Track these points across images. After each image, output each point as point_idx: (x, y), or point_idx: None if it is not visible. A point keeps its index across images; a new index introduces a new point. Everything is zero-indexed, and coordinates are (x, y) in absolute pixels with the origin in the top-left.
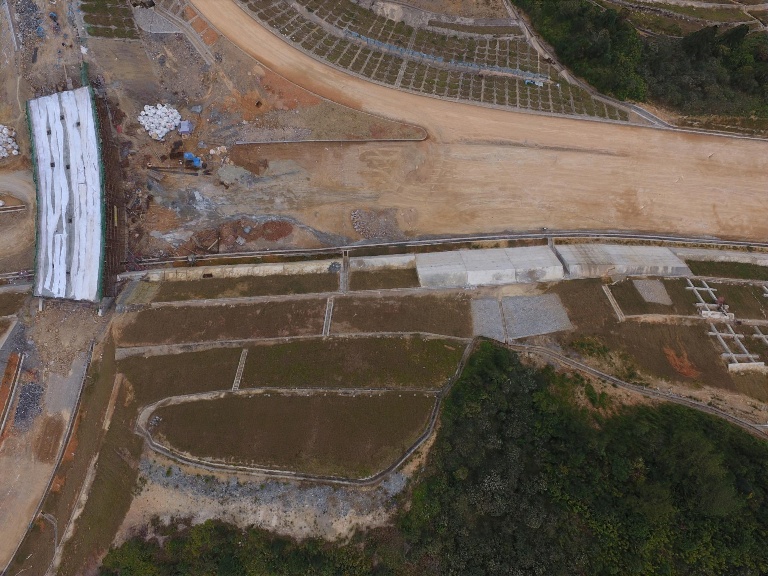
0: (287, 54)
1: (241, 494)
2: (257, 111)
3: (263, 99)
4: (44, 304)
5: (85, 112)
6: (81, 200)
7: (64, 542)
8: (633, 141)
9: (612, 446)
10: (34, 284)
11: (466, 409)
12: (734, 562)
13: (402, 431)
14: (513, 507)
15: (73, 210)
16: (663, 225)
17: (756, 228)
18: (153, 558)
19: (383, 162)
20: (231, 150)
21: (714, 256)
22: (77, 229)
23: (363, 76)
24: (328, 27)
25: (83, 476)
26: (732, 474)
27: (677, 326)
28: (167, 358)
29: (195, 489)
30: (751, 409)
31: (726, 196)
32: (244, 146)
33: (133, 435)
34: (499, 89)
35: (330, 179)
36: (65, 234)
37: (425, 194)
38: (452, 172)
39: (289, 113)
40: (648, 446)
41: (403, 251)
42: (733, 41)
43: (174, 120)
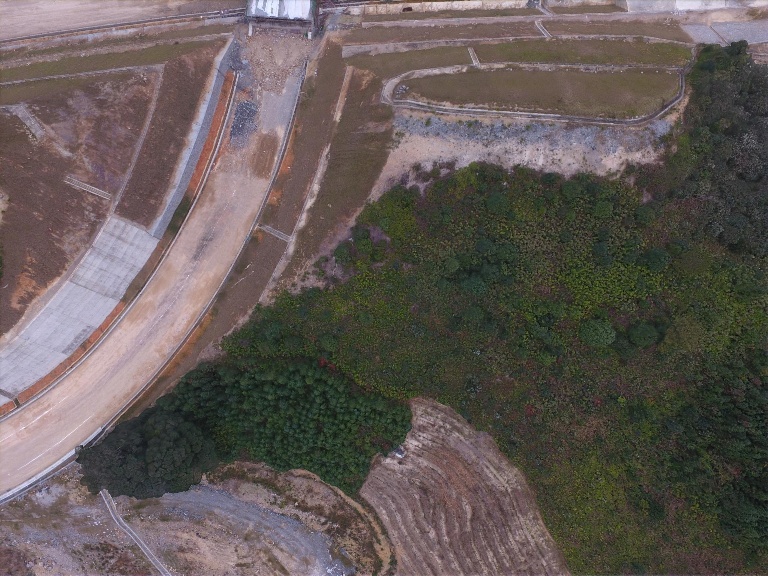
0: None
1: (506, 135)
2: None
3: None
4: (254, 29)
5: None
6: None
7: (297, 231)
8: None
9: None
10: (247, 5)
11: (718, 74)
12: None
13: (657, 90)
14: None
15: None
16: None
17: None
18: (416, 203)
19: None
20: None
21: None
22: None
23: None
24: None
25: (314, 168)
26: None
27: None
28: (394, 54)
29: (458, 134)
30: None
31: None
32: None
33: (379, 105)
34: None
35: None
36: None
37: None
38: None
39: None
40: None
41: None
42: None
43: None
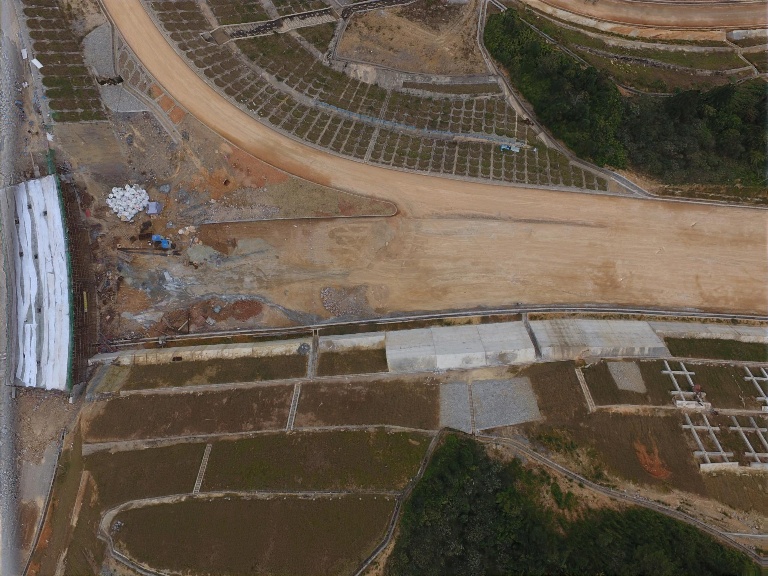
0: (254, 130)
1: None
2: (225, 189)
3: (231, 177)
4: (17, 391)
5: (52, 201)
6: (49, 290)
7: None
8: (611, 211)
9: (574, 556)
10: (6, 373)
11: (425, 517)
12: None
13: (359, 541)
14: None
15: (42, 300)
16: (643, 298)
17: (741, 299)
18: None
19: (353, 238)
20: (200, 230)
21: (695, 333)
22: (46, 319)
23: (332, 151)
24: (298, 96)
25: (53, 570)
26: None
27: (650, 418)
28: (132, 454)
29: None
30: (721, 516)
31: (710, 266)
32: (212, 226)
33: (96, 539)
34: (473, 158)
35: (299, 257)
36: (35, 324)
37: (396, 270)
38: (423, 247)
39: (257, 191)
40: (610, 560)
41: (374, 329)
42: (720, 101)
43: (142, 201)
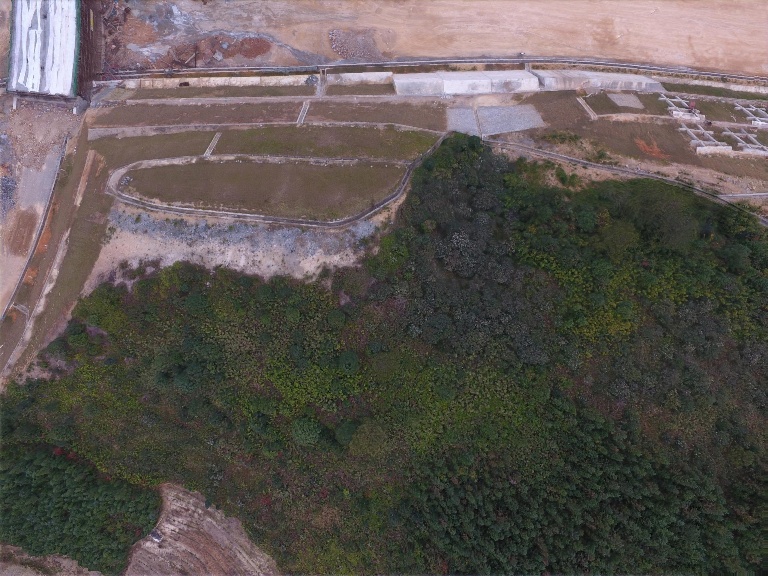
0: None
1: (209, 235)
2: None
3: None
4: (18, 102)
5: None
6: None
7: (35, 316)
8: None
9: None
10: (8, 79)
11: (436, 172)
12: (694, 293)
13: (372, 188)
14: (481, 265)
15: (48, 6)
16: (639, 55)
17: (730, 61)
18: (121, 301)
19: None
20: None
21: (688, 80)
22: (52, 24)
23: None
24: None
25: (54, 252)
26: (695, 219)
27: (648, 124)
28: (140, 138)
29: (164, 232)
30: (717, 181)
31: (701, 28)
32: None
33: (103, 196)
34: None
35: None
36: (40, 29)
37: (403, 16)
38: None
39: None
40: (614, 202)
41: (381, 71)
42: None
43: None
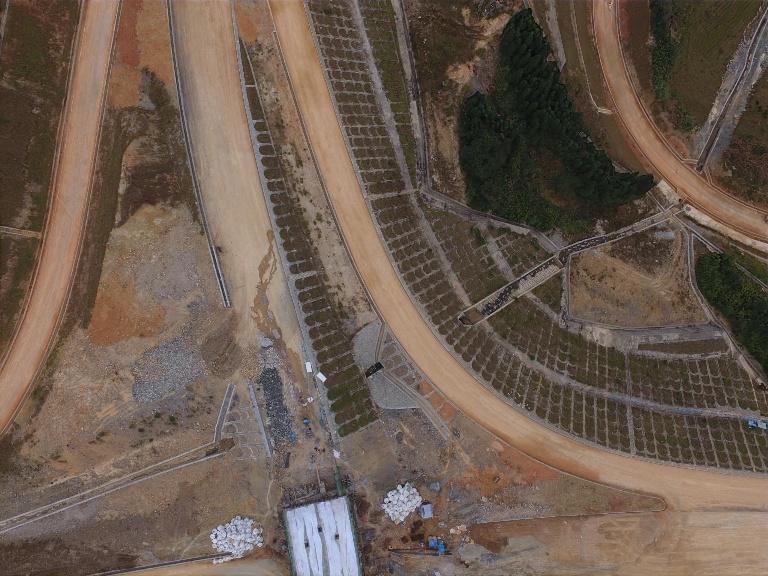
0: (523, 425)
1: None
2: (495, 485)
3: (501, 473)
4: None
5: (343, 524)
6: None
7: None
8: None
9: None
10: None
11: None
12: None
13: None
14: None
15: None
16: None
17: None
18: None
19: (621, 533)
20: (471, 529)
21: None
22: None
23: (600, 445)
24: (550, 374)
25: None
26: None
27: None
28: None
29: None
30: None
31: None
32: (485, 525)
33: None
34: (728, 441)
35: (569, 553)
36: None
37: (663, 564)
38: (690, 540)
39: (529, 489)
40: None
41: None
42: None
43: (416, 504)
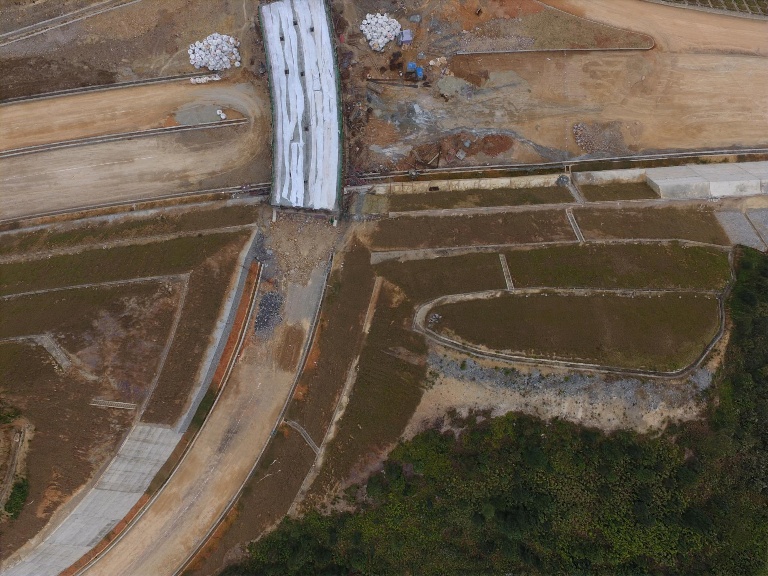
0: None
1: (544, 386)
2: (477, 20)
3: (483, 7)
4: (278, 215)
5: (319, 17)
6: (317, 107)
7: (326, 443)
8: None
9: None
10: (271, 193)
11: (760, 308)
12: None
13: (697, 329)
14: None
15: (309, 118)
16: None
17: None
18: (451, 450)
19: (607, 73)
20: (451, 61)
21: None
22: (314, 137)
23: None
24: None
25: (343, 379)
26: None
27: None
28: (424, 262)
29: (494, 381)
30: None
31: None
32: (465, 56)
33: (411, 333)
34: None
35: (552, 91)
36: (302, 142)
37: (650, 106)
38: (679, 83)
39: (511, 21)
40: None
41: (628, 166)
42: None
43: (395, 29)
